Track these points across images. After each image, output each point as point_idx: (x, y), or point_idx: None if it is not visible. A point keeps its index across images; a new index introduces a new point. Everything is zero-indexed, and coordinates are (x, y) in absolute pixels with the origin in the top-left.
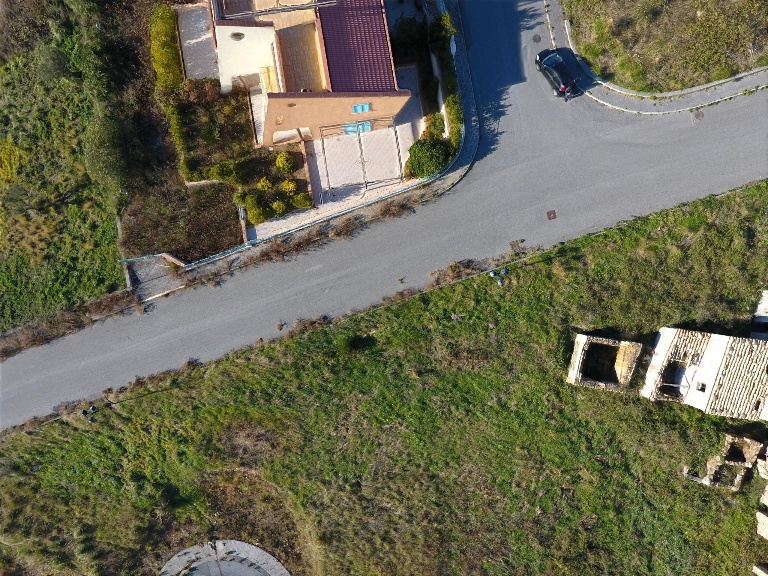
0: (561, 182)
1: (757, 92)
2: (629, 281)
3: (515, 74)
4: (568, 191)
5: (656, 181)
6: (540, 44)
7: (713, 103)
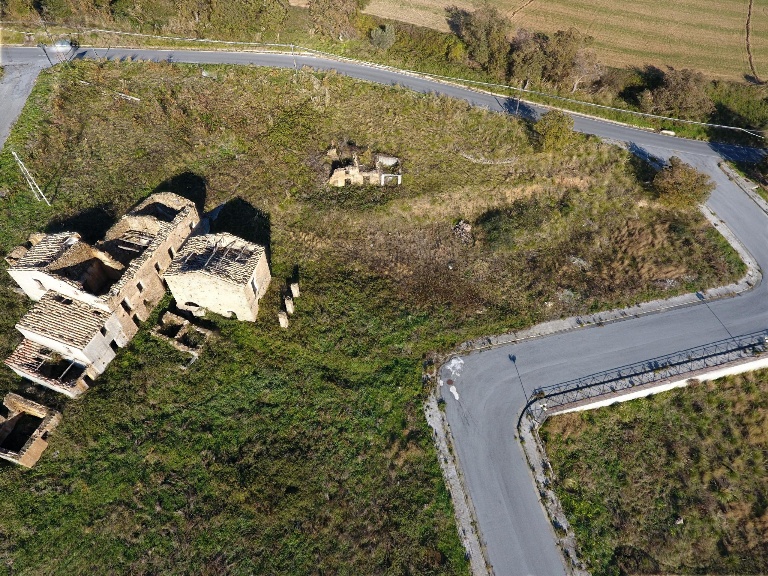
0: None
1: None
2: None
3: None
4: None
5: None
6: None
7: None
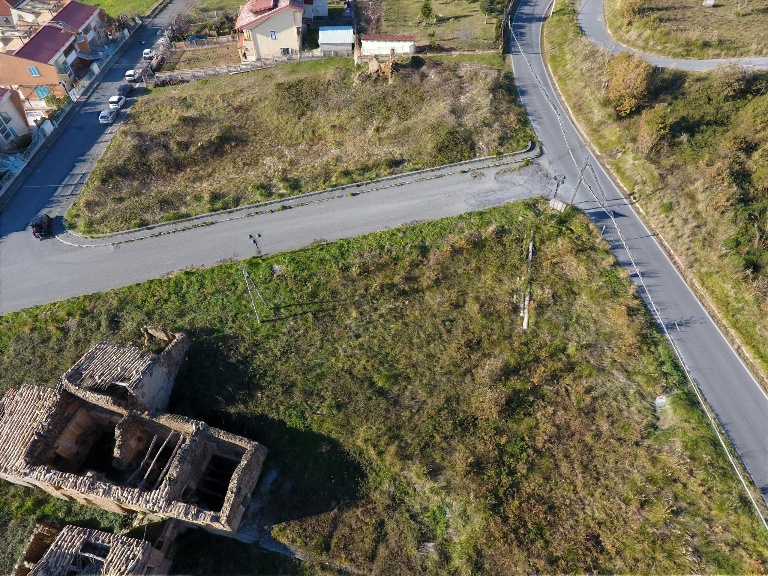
0: (1, 284)
1: (161, 236)
2: (12, 356)
3: (20, 227)
4: (1, 289)
5: (66, 284)
6: (49, 214)
7: (129, 241)
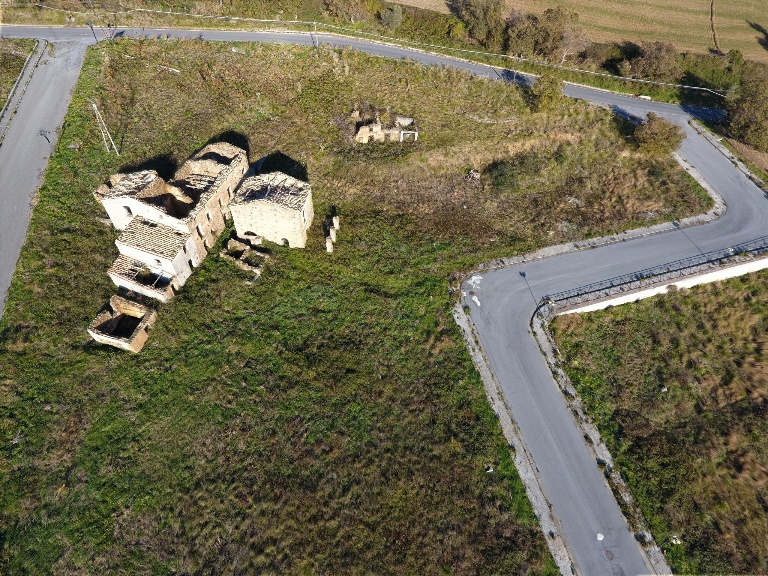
0: None
1: None
2: (62, 300)
3: None
4: None
5: None
6: None
7: None
